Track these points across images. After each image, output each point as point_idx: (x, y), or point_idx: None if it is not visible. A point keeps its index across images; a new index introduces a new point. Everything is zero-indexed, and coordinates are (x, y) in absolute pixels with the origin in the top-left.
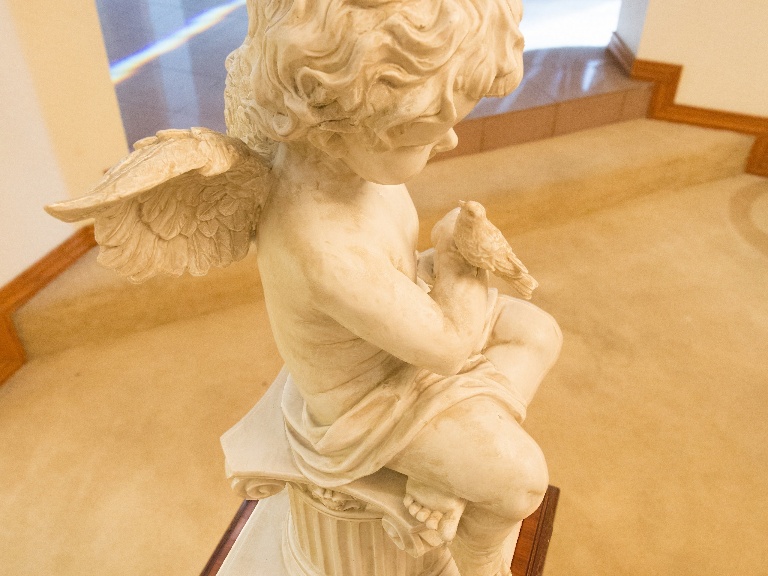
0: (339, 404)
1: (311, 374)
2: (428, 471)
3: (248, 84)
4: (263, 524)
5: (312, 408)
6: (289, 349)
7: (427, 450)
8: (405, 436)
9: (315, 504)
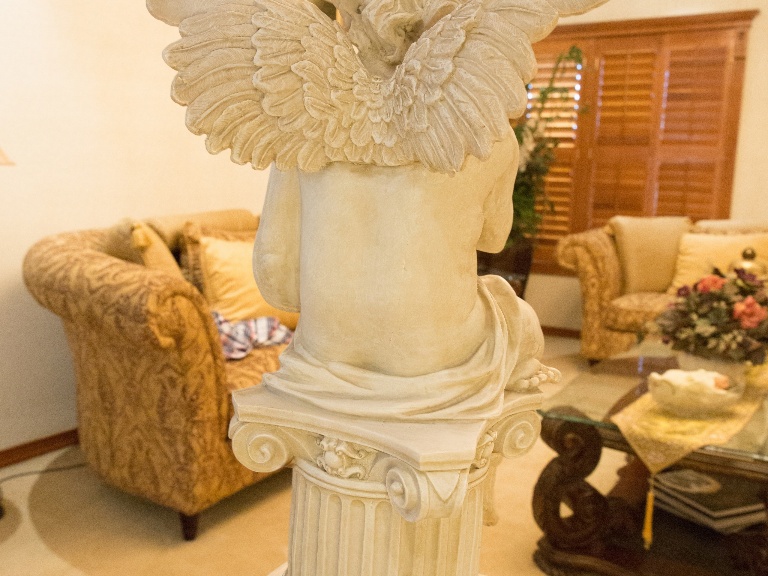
0: (482, 313)
1: (472, 287)
2: (528, 335)
3: (392, 1)
4: None
5: (454, 350)
6: (456, 270)
7: (523, 315)
8: (519, 306)
9: (475, 474)
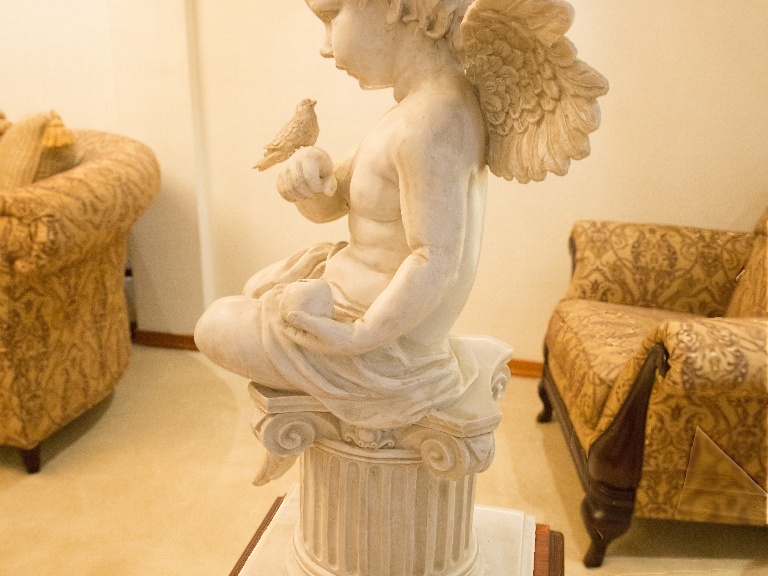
0: None
1: None
2: None
3: None
4: (508, 566)
5: None
6: None
7: None
8: None
9: None
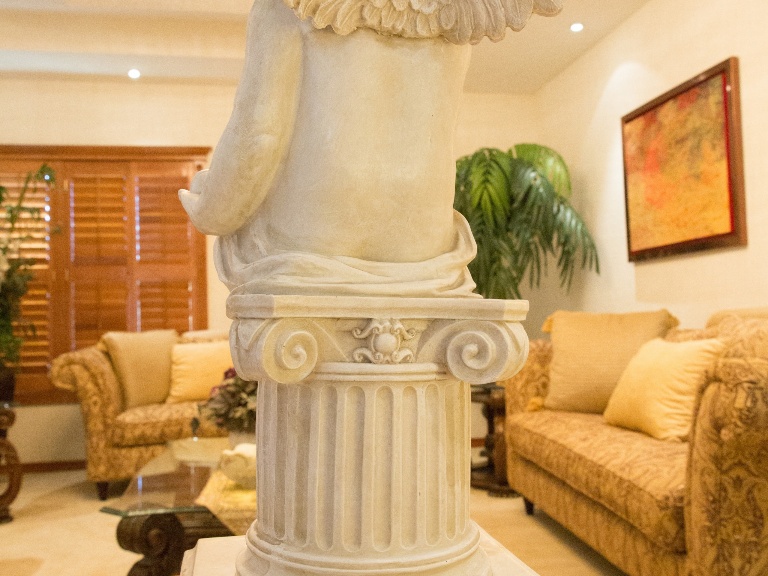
0: None
1: None
2: None
3: None
4: None
5: None
6: None
7: None
8: None
9: None
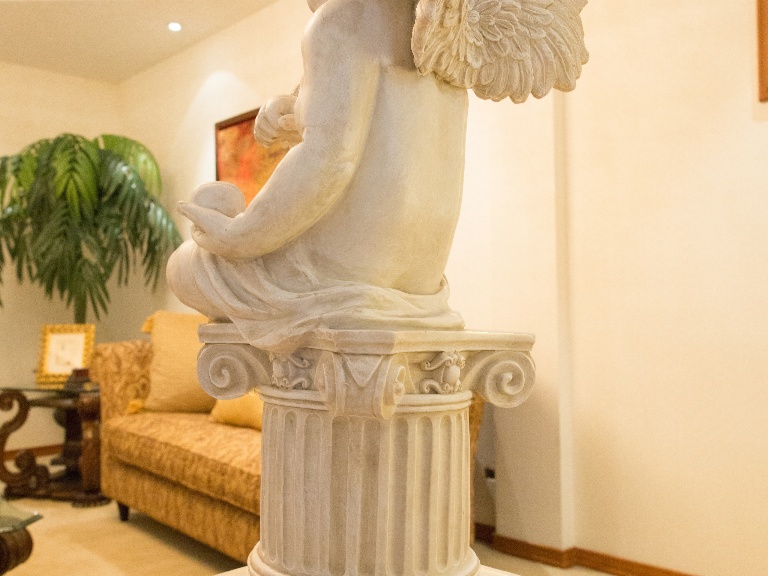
0: None
1: None
2: None
3: None
4: None
5: None
6: None
7: None
8: None
9: None
